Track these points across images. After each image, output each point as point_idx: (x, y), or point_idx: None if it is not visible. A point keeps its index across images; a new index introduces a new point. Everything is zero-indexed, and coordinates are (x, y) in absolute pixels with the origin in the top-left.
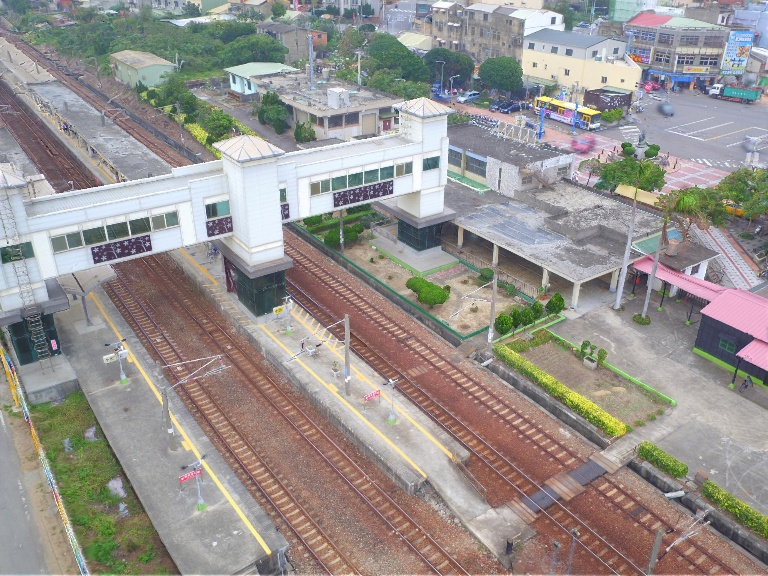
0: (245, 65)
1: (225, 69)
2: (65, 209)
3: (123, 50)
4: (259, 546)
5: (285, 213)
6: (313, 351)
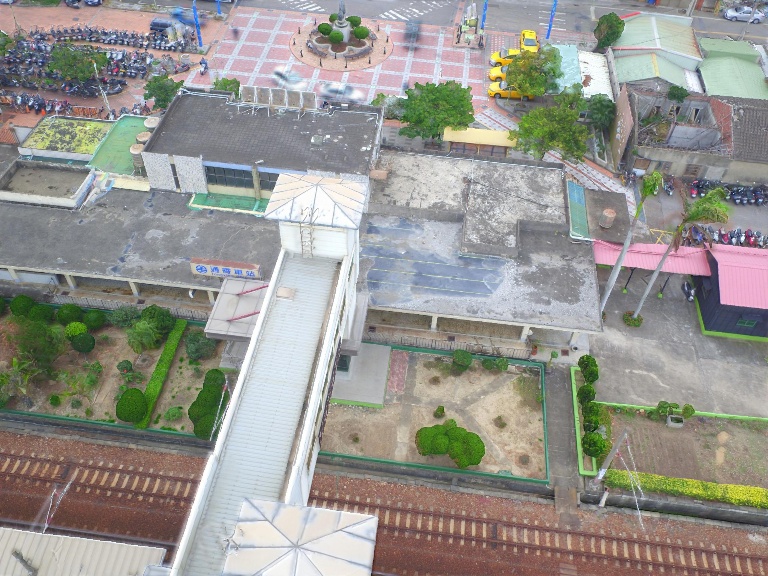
0: None
1: None
2: None
3: None
4: None
5: None
6: None
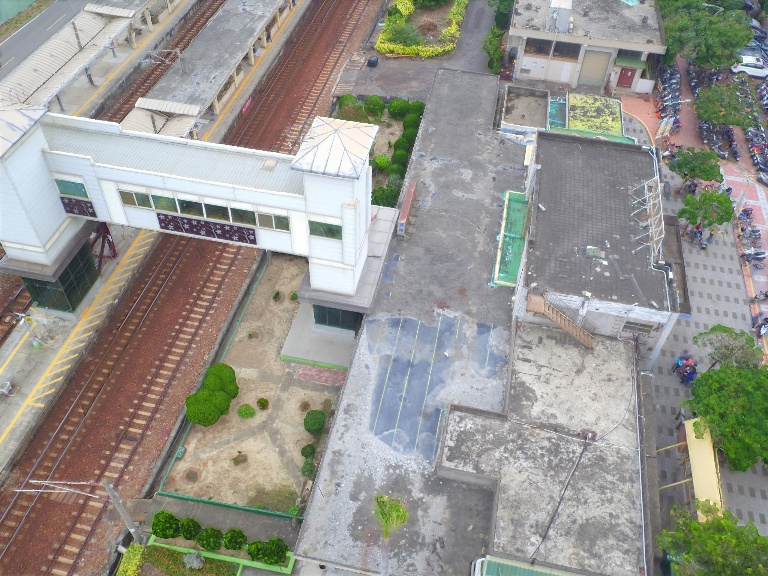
0: None
1: None
2: None
3: None
4: None
5: (89, 210)
6: (3, 391)
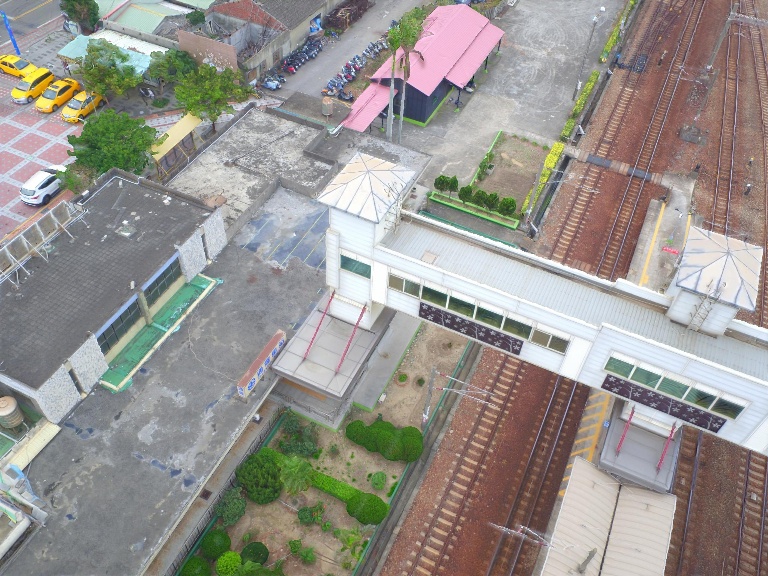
0: None
1: None
2: None
3: None
4: None
5: None
6: None
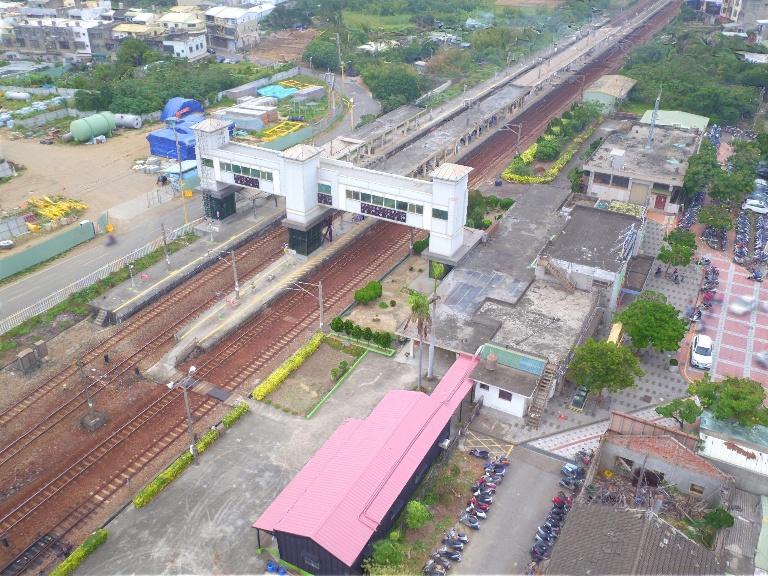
0: (668, 111)
1: (648, 110)
2: (232, 151)
3: (616, 74)
4: (116, 308)
5: (329, 201)
6: (270, 277)
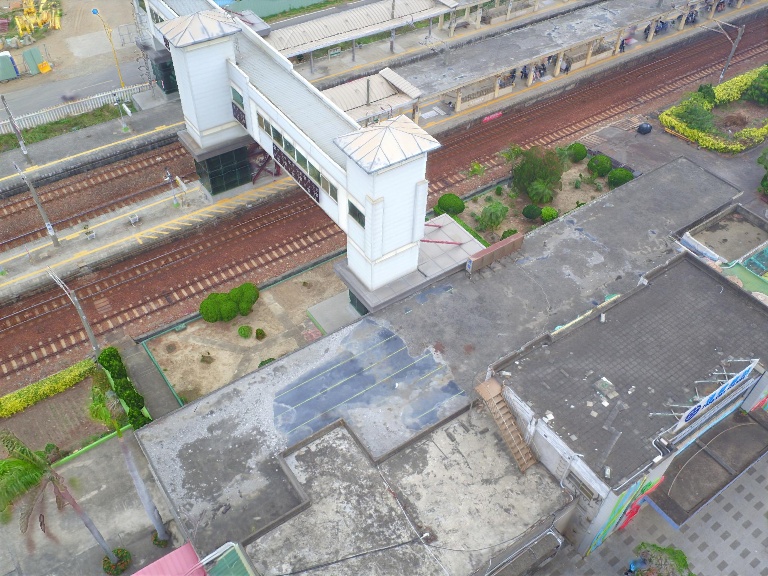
0: None
1: None
2: None
3: None
4: None
5: None
6: (131, 219)
